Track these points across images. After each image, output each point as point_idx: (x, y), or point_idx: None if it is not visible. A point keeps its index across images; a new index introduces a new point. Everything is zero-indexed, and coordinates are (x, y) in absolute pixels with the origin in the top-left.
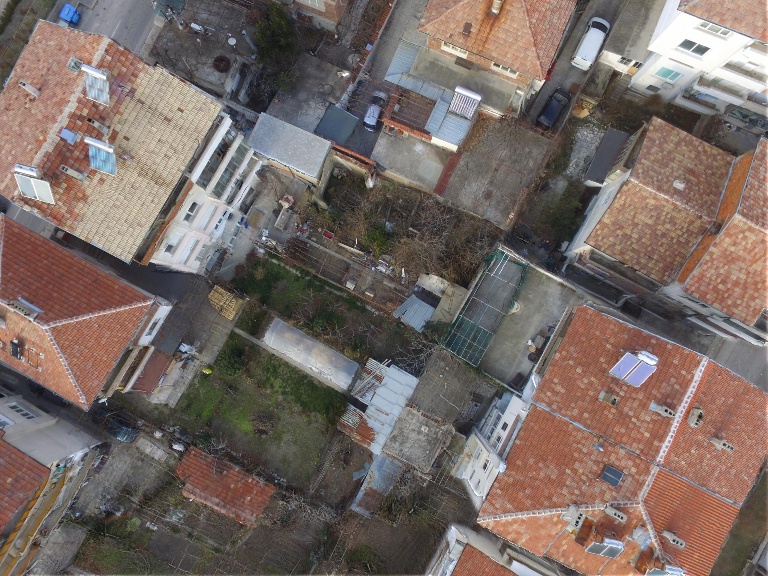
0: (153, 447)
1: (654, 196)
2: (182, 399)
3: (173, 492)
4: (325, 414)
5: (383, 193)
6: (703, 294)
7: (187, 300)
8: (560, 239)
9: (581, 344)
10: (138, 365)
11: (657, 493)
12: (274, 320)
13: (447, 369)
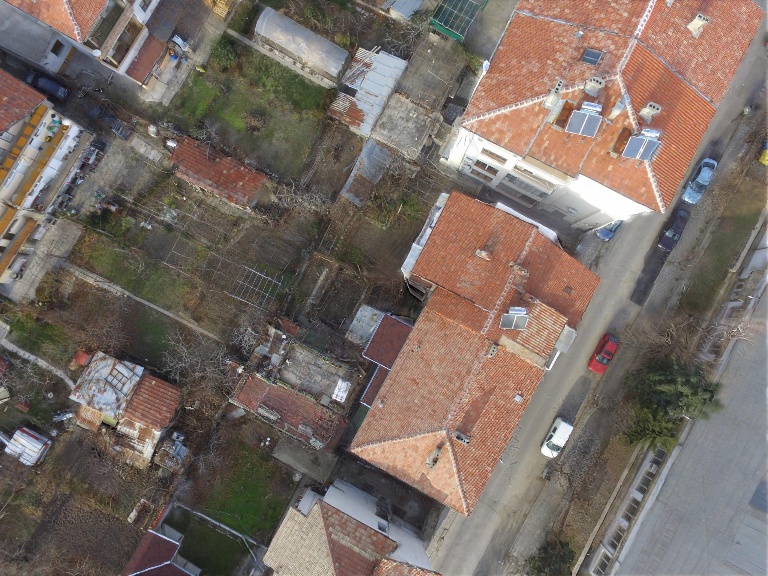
0: (147, 147)
1: None
2: (176, 98)
3: (167, 190)
4: (316, 109)
5: None
6: None
7: None
8: None
9: None
10: (132, 43)
11: (635, 68)
12: (266, 9)
13: (435, 44)
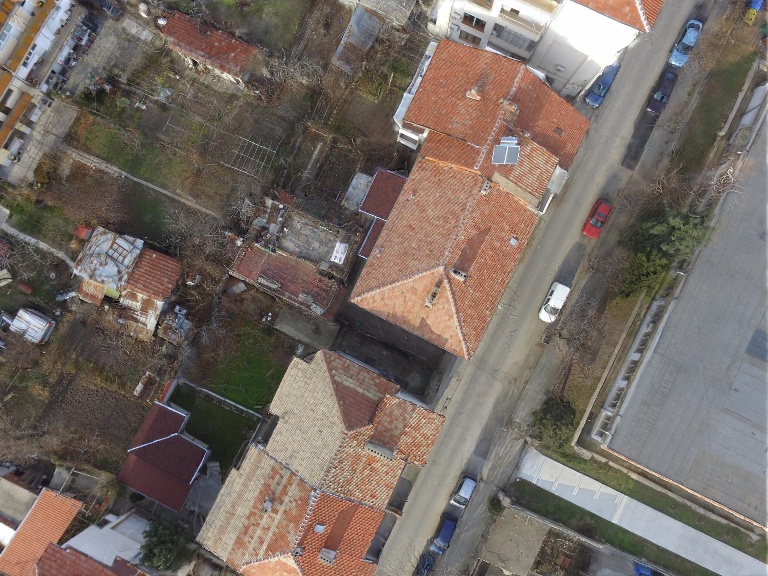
0: (139, 28)
1: None
2: None
3: (160, 69)
4: None
5: None
6: None
7: None
8: None
9: None
10: None
11: None
12: None
13: None
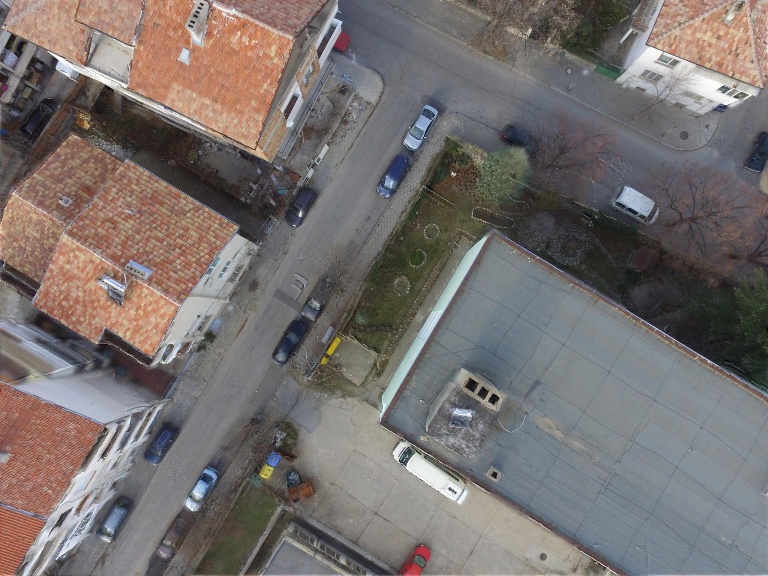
0: None
1: (34, 211)
2: None
3: None
4: None
5: None
6: (50, 310)
7: None
8: None
9: None
10: None
11: None
12: None
13: None
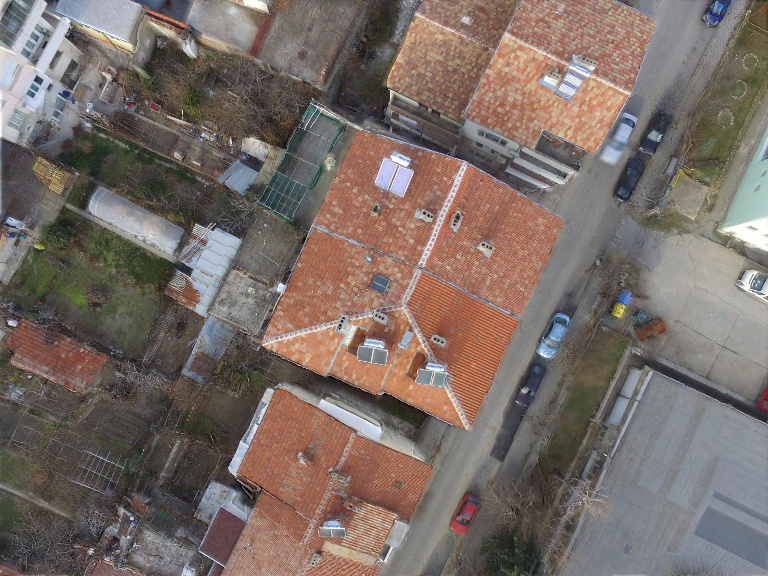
0: None
1: (441, 31)
2: (16, 276)
3: (11, 370)
4: (157, 284)
5: (208, 64)
6: (484, 119)
7: (8, 170)
8: (385, 103)
9: (358, 166)
10: None
11: (422, 297)
12: (98, 189)
13: (265, 226)
